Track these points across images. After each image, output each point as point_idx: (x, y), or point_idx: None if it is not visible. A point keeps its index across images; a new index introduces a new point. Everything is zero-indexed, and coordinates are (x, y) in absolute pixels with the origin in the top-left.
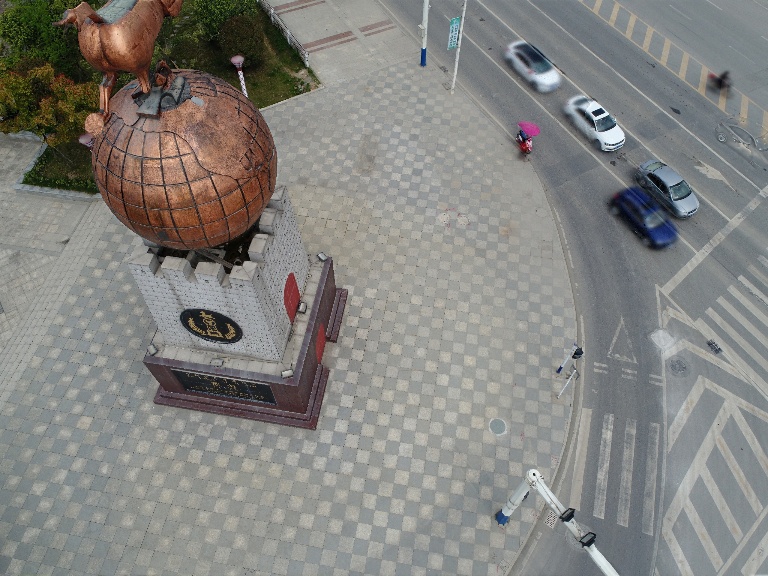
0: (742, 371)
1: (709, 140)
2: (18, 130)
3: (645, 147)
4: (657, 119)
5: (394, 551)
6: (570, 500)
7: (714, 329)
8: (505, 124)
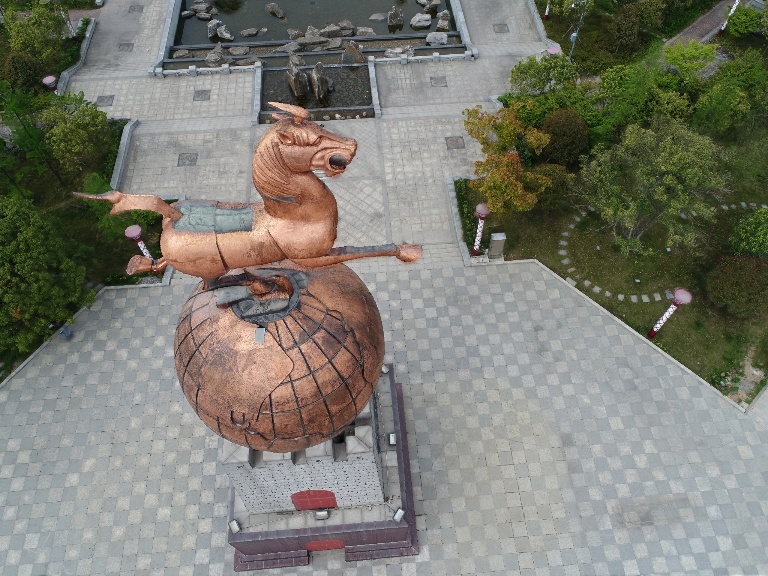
0: None
1: None
2: (485, 151)
3: None
4: None
5: None
6: None
7: None
8: None
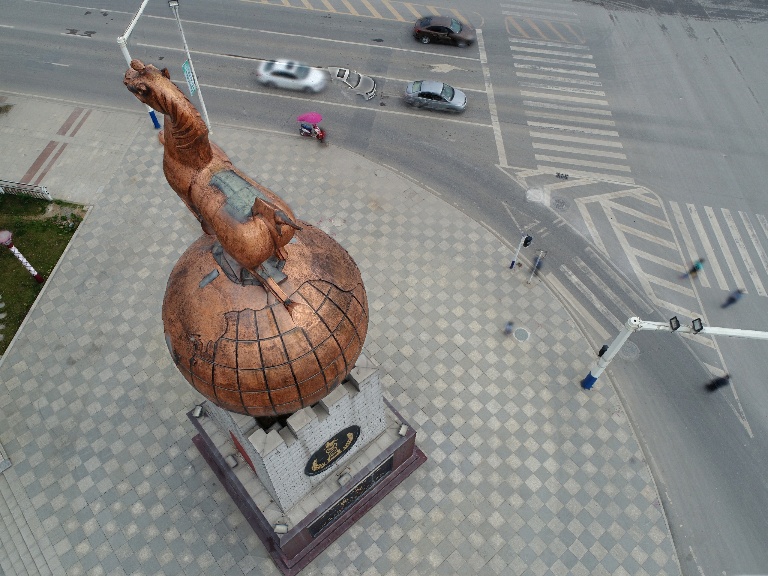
0: (588, 178)
1: (419, 47)
2: None
3: (389, 79)
4: (374, 54)
5: (562, 473)
6: (601, 336)
7: (551, 166)
8: (279, 129)
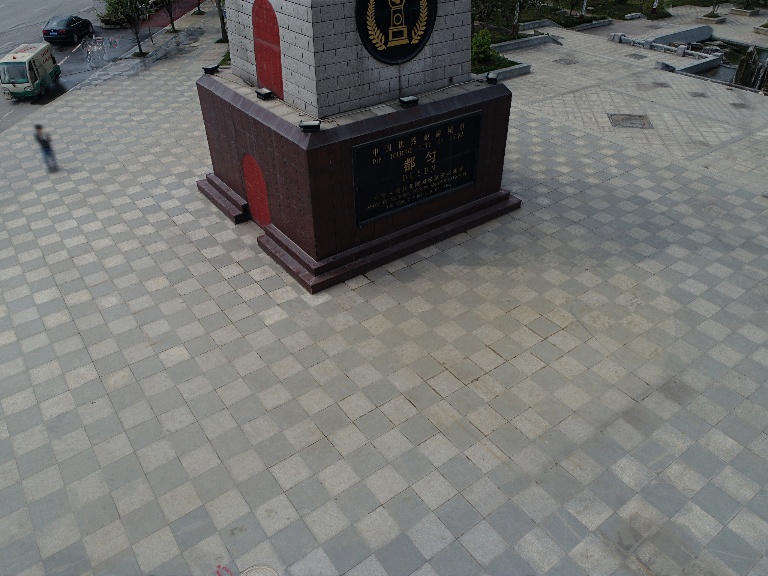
0: None
1: None
2: None
3: None
4: None
5: (36, 181)
6: None
7: None
8: None
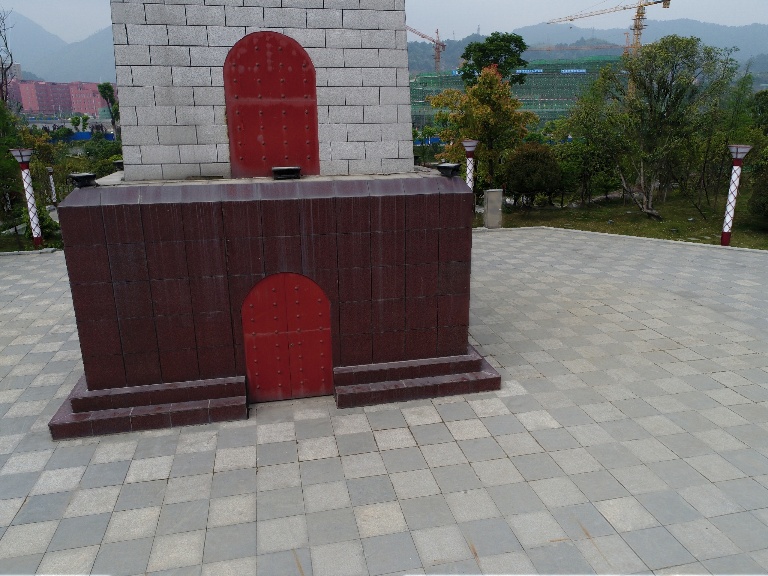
0: None
1: None
2: (455, 160)
3: None
4: None
5: None
6: None
7: None
8: None
